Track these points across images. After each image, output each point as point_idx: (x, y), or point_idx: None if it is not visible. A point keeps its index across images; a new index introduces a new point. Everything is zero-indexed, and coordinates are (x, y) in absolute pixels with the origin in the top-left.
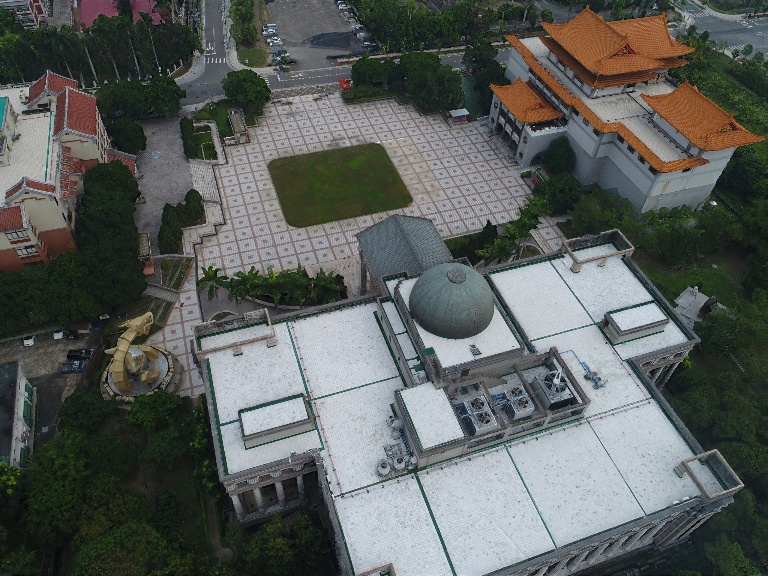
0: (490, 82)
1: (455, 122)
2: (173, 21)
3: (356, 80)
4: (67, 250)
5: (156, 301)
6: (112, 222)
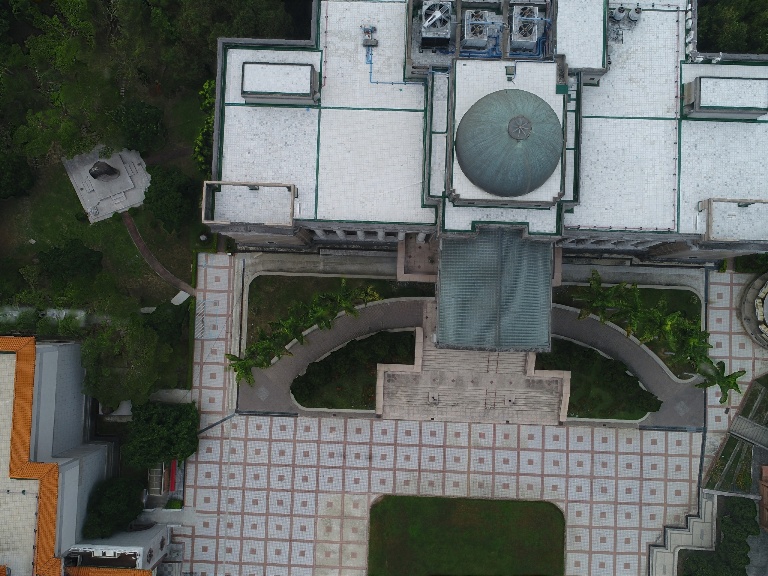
0: None
1: None
2: None
3: None
4: None
5: (761, 422)
6: None
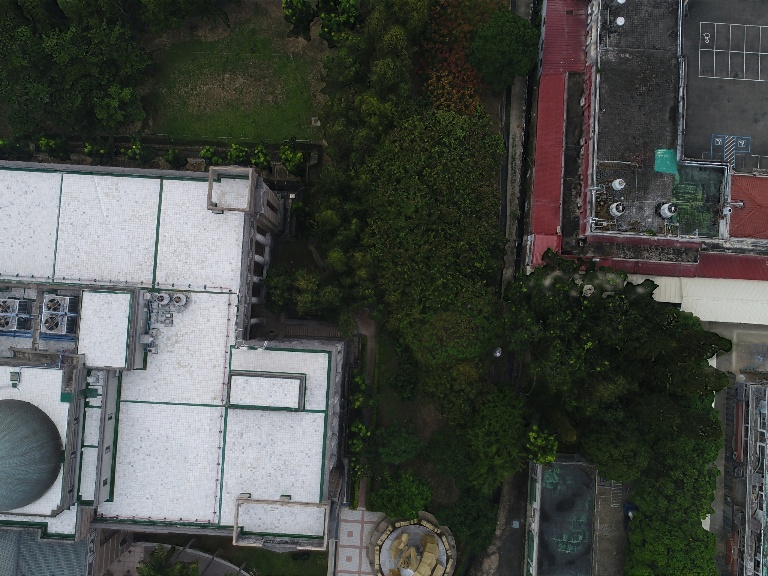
0: None
1: None
2: None
3: None
4: None
5: None
6: None
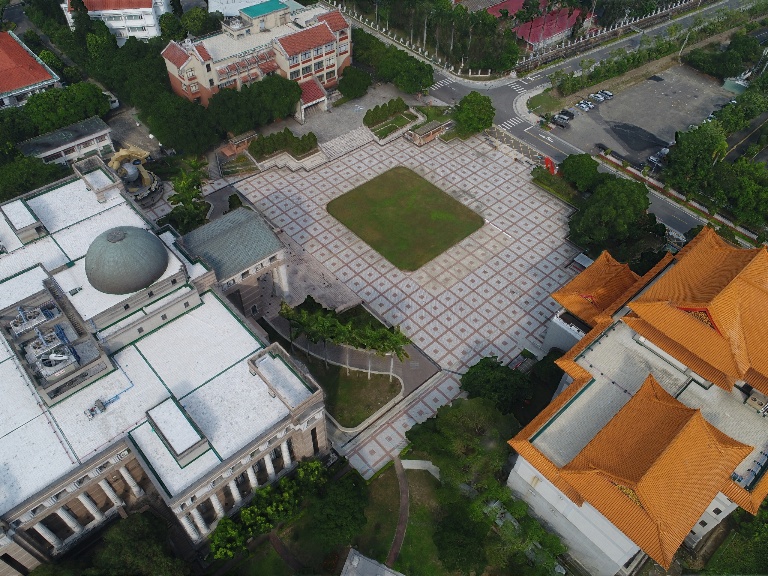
0: (649, 262)
1: (575, 267)
2: None
3: (560, 168)
4: None
5: (206, 169)
6: None
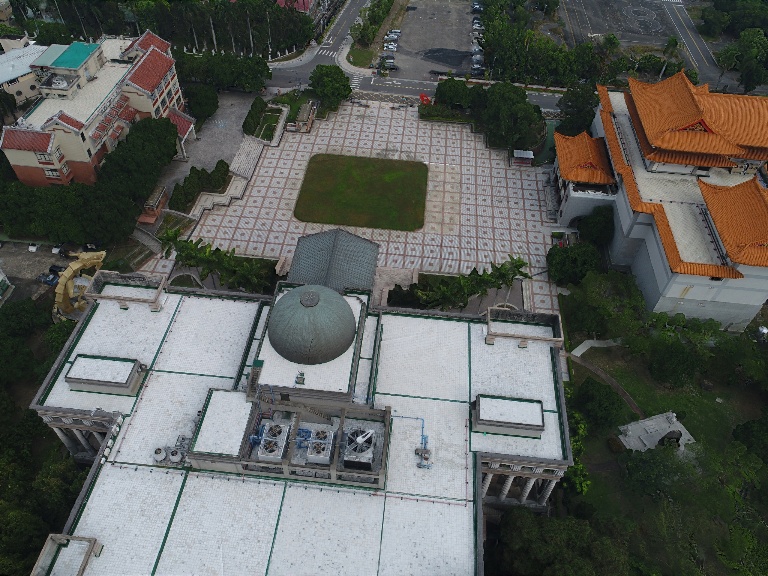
0: (568, 130)
1: (516, 163)
2: (308, 11)
3: (437, 98)
4: (89, 182)
5: (142, 247)
6: (128, 168)
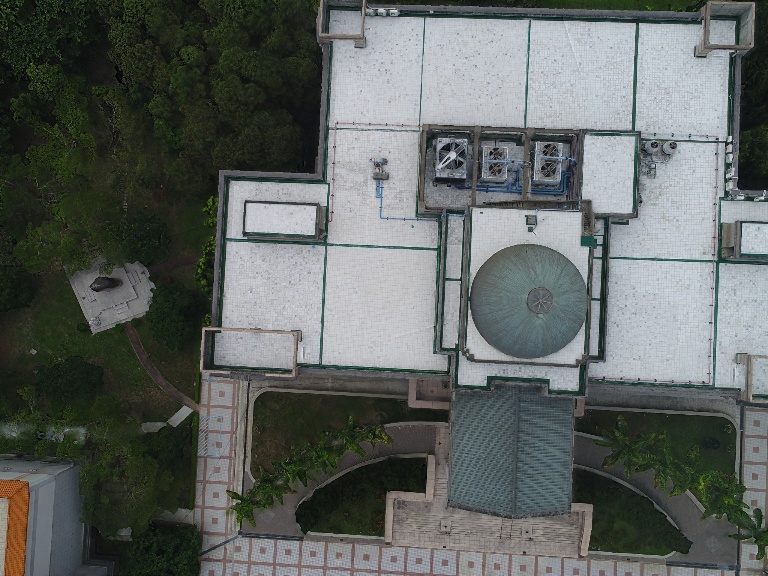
0: None
1: None
2: None
3: None
4: None
5: None
6: None
